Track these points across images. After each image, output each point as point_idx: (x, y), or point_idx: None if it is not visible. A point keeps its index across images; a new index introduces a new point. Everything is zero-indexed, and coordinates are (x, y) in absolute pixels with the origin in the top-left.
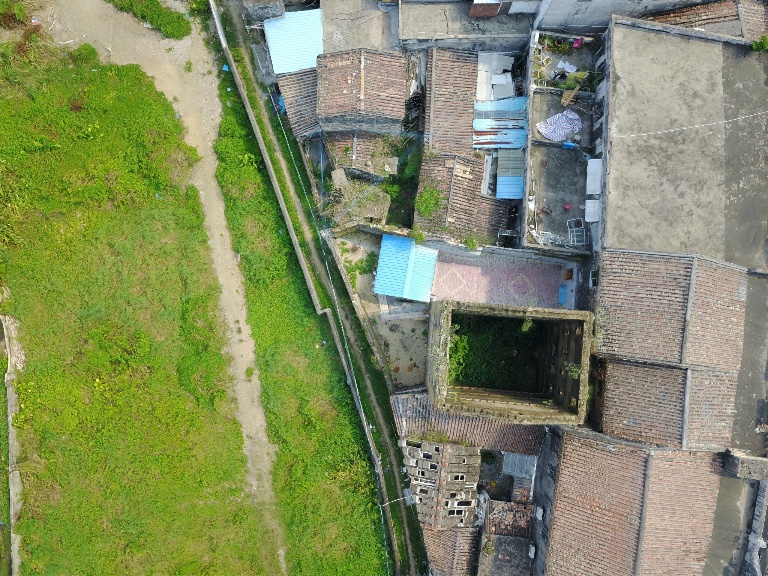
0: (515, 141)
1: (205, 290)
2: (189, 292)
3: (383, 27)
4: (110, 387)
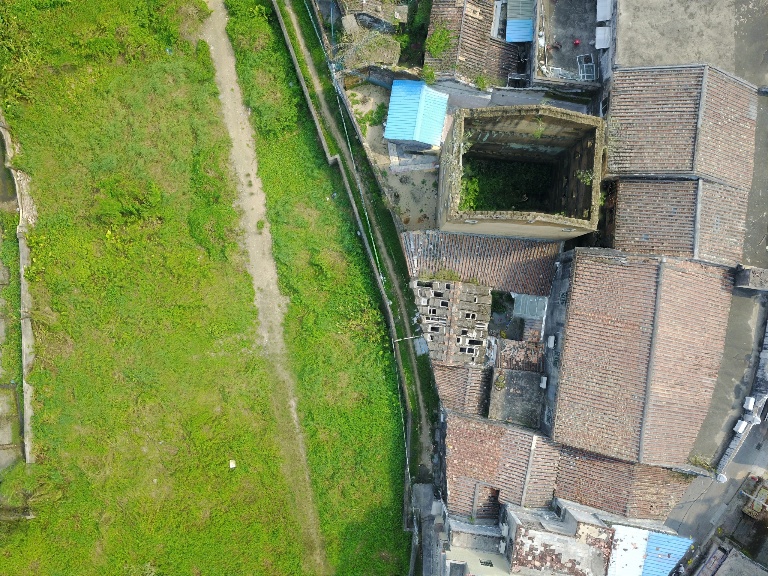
0: None
1: (216, 143)
2: (200, 144)
3: None
4: (122, 239)
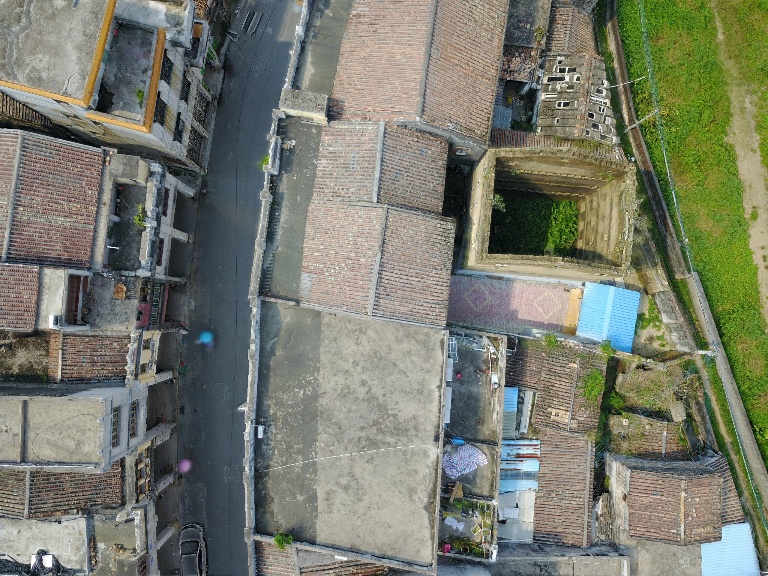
0: None
1: None
2: None
3: (637, 571)
4: None
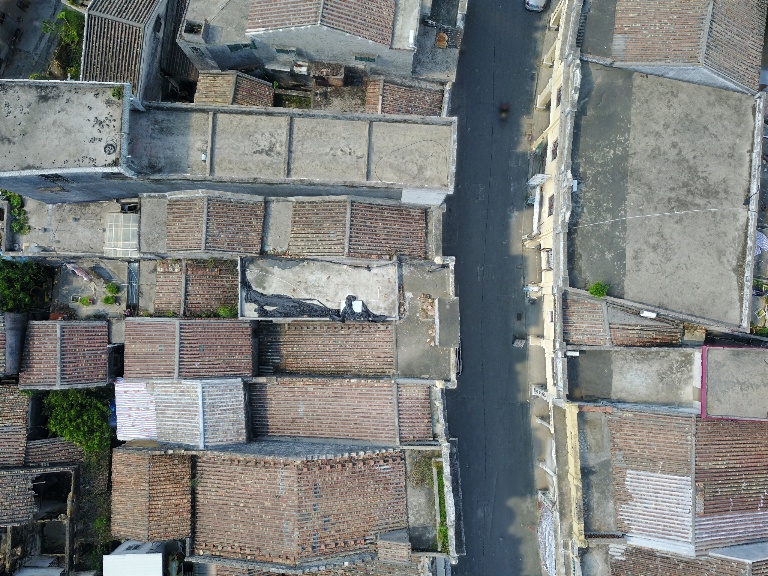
0: None
1: None
2: None
3: None
4: None
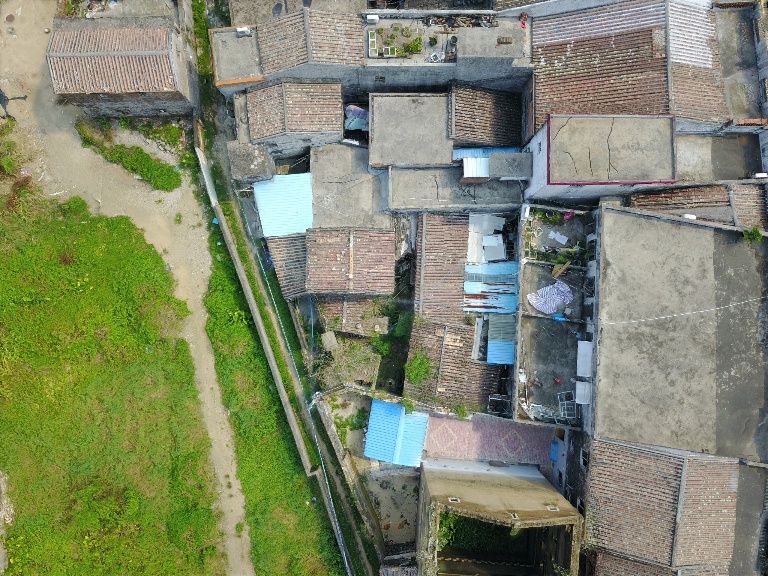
0: (506, 306)
1: (195, 446)
2: (179, 449)
3: (373, 191)
4: (99, 544)
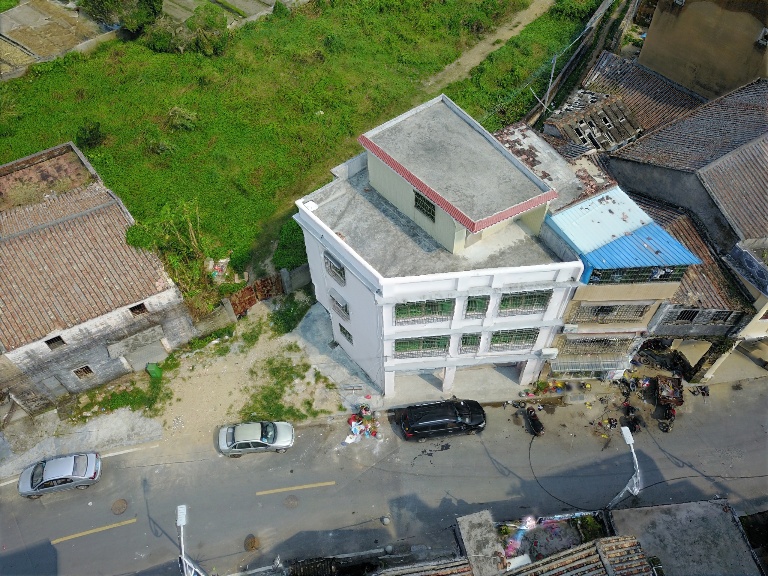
0: None
1: None
2: None
3: None
4: None
